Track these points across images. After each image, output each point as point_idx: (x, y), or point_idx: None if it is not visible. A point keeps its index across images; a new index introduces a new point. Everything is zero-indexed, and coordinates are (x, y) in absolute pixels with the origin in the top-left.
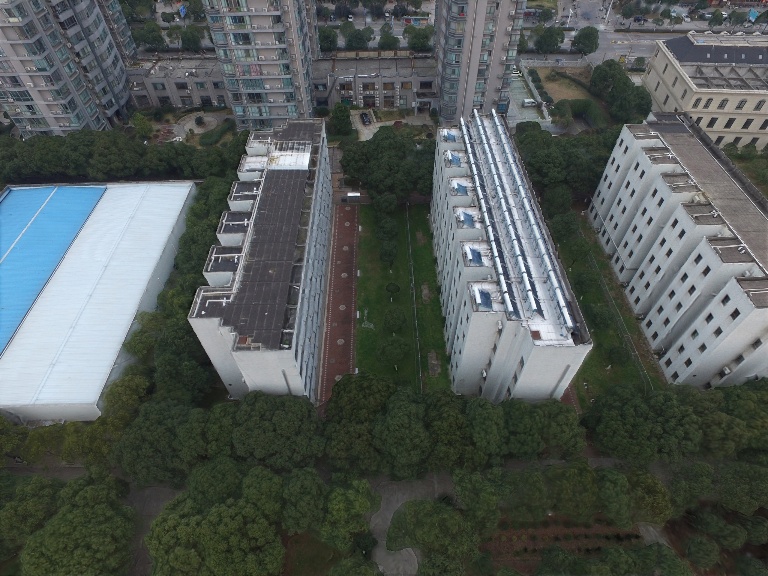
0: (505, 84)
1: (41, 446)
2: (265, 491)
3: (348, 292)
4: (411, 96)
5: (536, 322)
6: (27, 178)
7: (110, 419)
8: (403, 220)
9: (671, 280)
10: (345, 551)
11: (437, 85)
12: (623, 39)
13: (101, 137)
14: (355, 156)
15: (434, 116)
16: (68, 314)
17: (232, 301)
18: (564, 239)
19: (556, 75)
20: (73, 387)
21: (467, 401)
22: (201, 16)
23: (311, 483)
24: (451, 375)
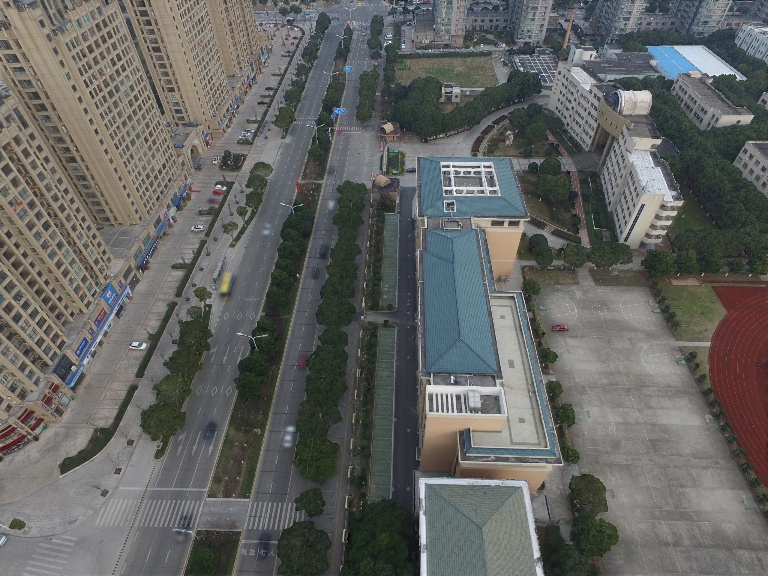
0: None
1: None
2: None
3: None
4: None
5: None
6: None
7: (767, 73)
8: None
9: None
10: None
11: None
12: None
13: (671, 30)
14: None
15: None
16: None
17: None
18: None
19: None
20: None
21: None
22: None
23: None
24: None
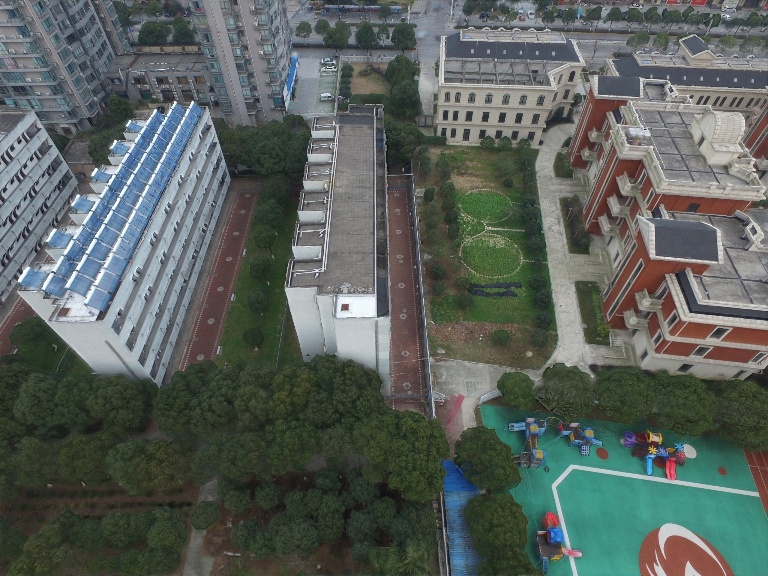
0: (272, 78)
1: None
2: None
3: None
4: (208, 90)
5: (75, 300)
6: None
7: None
8: None
9: None
10: None
11: None
12: None
13: None
14: (96, 147)
15: None
16: None
17: None
18: (287, 228)
19: (368, 70)
20: None
21: None
22: None
23: None
24: None
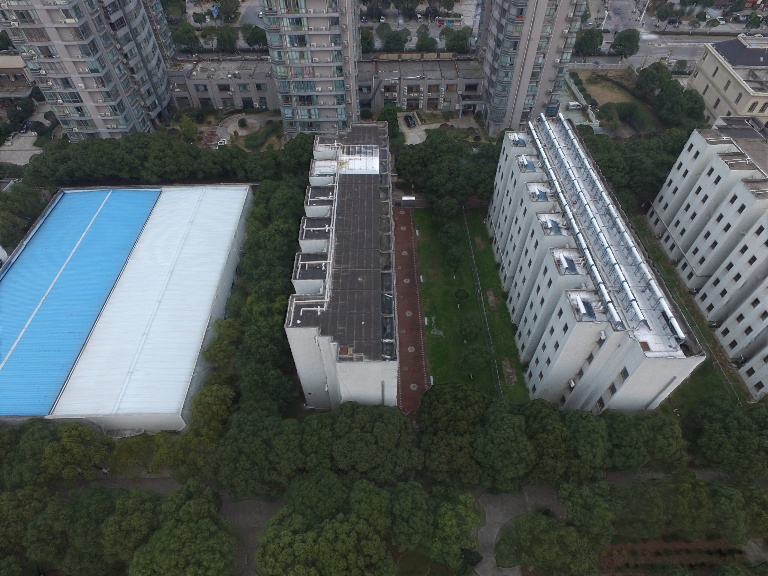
0: (557, 87)
1: (130, 457)
2: (376, 506)
3: (413, 298)
4: (455, 98)
5: (642, 333)
6: (78, 181)
7: (205, 430)
8: (461, 225)
9: (755, 288)
10: (458, 568)
11: (483, 87)
12: (659, 41)
13: (156, 140)
14: (412, 160)
15: (479, 119)
16: (139, 321)
17: (326, 310)
18: None
19: (597, 78)
20: (154, 396)
21: (563, 412)
22: (231, 17)
23: (421, 498)
24: (529, 384)
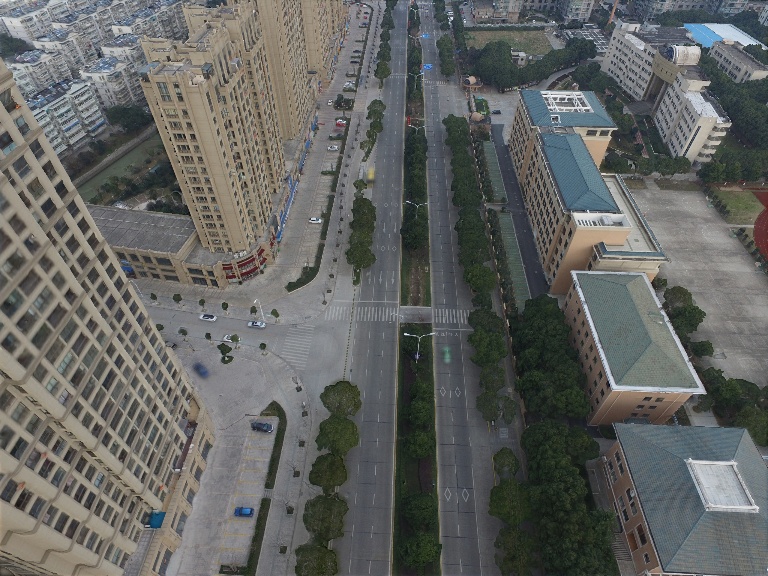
0: None
1: None
2: None
3: None
4: None
5: None
6: None
7: None
8: None
9: None
10: None
11: None
12: None
13: (702, 10)
14: None
15: None
16: None
17: None
18: None
19: None
20: None
21: None
22: None
23: None
24: None
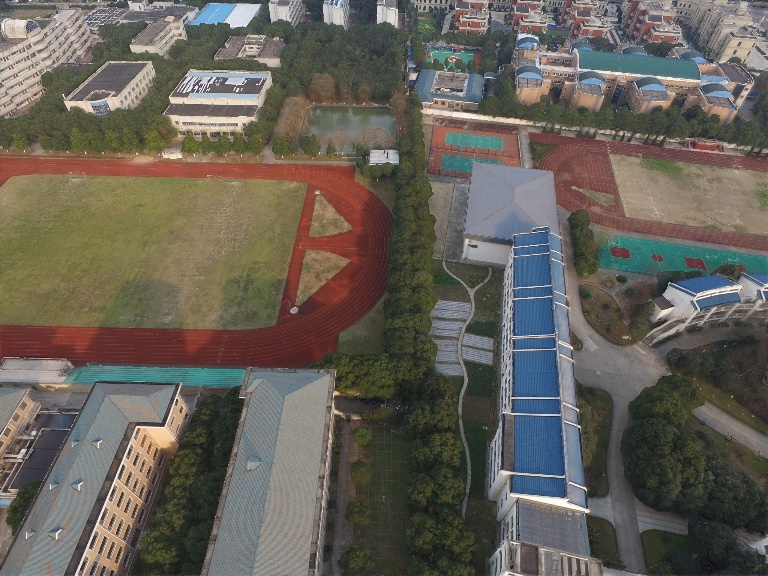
0: None
1: None
2: (282, 26)
3: None
4: None
5: (335, 6)
6: None
7: (252, 22)
8: (322, 18)
9: None
10: None
11: None
12: None
13: None
14: (310, 0)
15: None
16: None
17: None
18: None
19: None
20: None
21: None
22: None
23: None
24: None
